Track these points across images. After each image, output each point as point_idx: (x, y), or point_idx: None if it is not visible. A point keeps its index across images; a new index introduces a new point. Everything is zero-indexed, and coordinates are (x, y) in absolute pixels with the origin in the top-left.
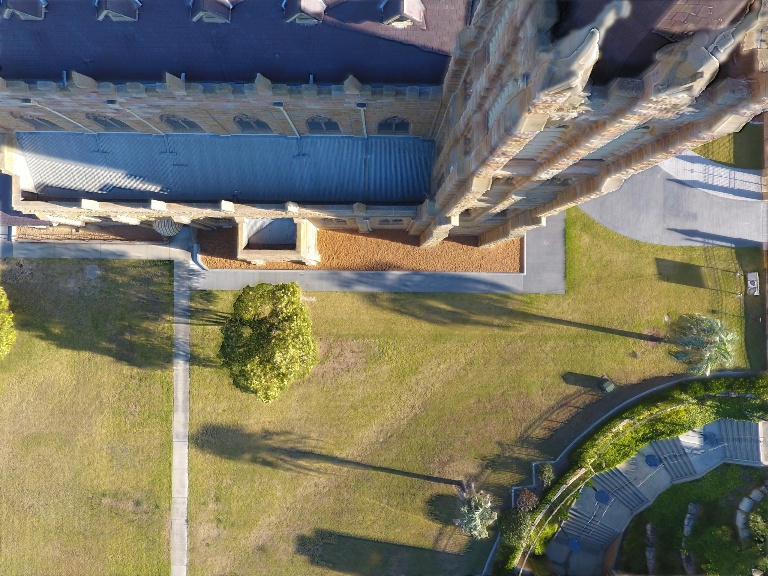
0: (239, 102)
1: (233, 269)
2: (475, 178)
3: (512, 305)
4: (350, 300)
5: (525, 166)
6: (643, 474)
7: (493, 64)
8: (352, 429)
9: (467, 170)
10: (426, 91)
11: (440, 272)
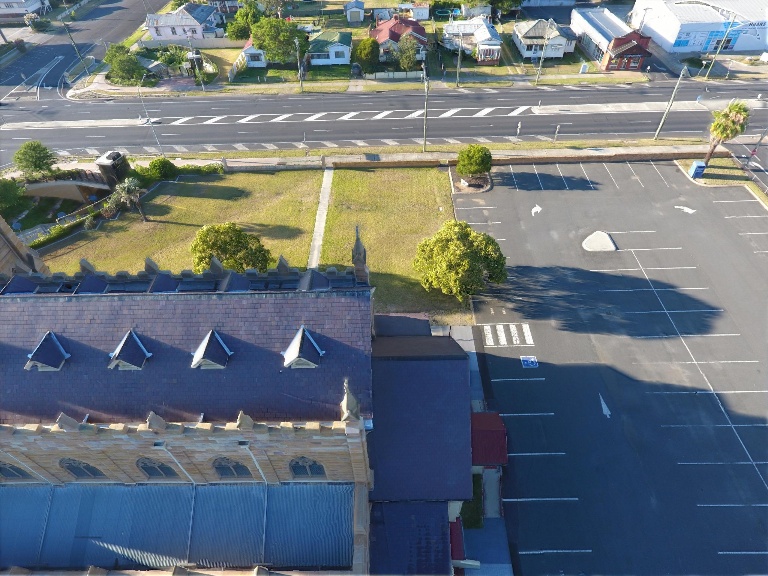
0: None
1: None
2: None
3: None
4: None
5: None
6: (35, 237)
7: None
8: None
9: None
10: None
11: None
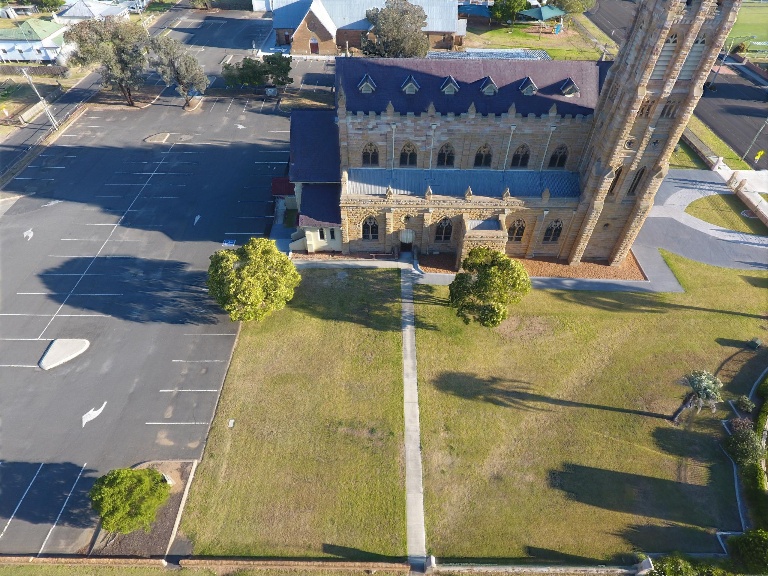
0: (494, 126)
1: (442, 273)
2: (639, 87)
3: (650, 298)
4: (529, 293)
5: (657, 87)
6: None
7: (639, 41)
8: (556, 375)
9: (634, 87)
10: (585, 118)
11: (589, 279)
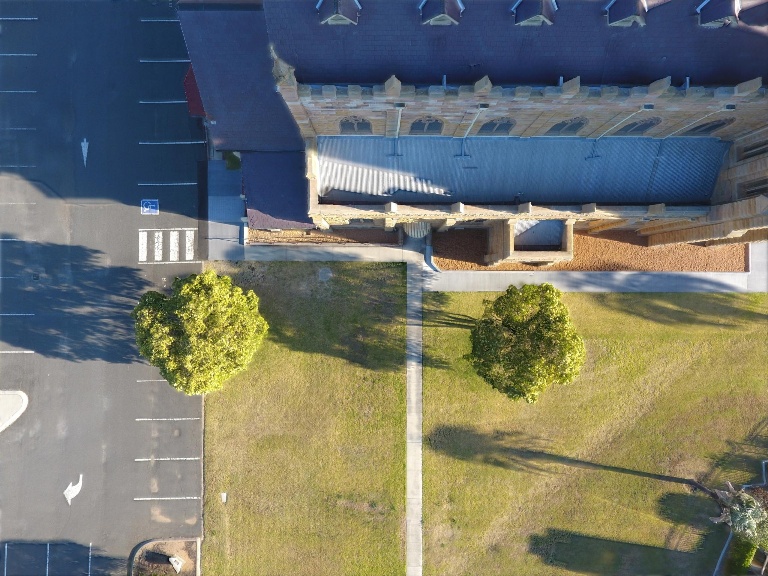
0: (609, 105)
1: (465, 270)
2: None
3: (737, 304)
4: (579, 300)
5: None
6: None
7: None
8: (582, 429)
9: None
10: None
11: (667, 272)
